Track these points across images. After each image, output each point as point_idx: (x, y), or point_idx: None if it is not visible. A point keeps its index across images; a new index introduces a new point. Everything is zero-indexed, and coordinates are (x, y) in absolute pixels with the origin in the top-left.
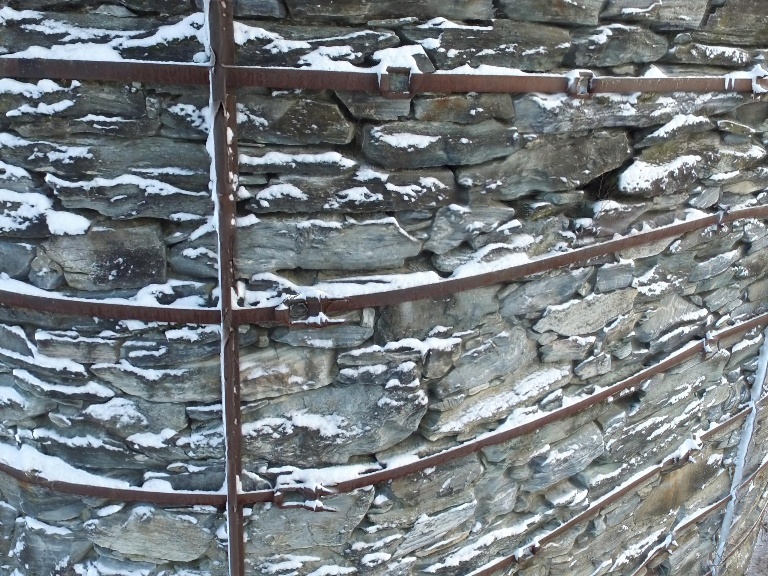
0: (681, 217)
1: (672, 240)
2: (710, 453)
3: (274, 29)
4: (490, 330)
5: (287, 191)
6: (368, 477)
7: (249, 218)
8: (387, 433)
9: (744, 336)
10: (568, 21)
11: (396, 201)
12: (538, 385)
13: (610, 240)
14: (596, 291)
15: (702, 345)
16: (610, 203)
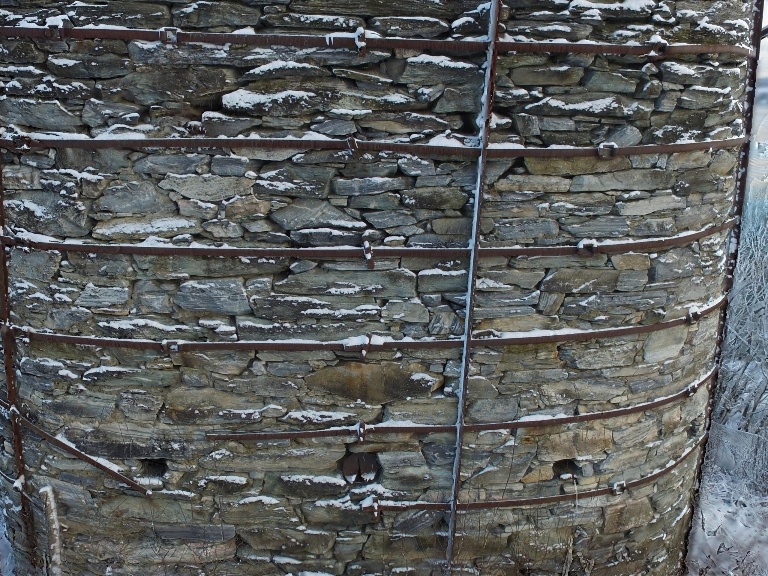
0: (299, 136)
1: (296, 153)
2: (419, 371)
3: (14, 11)
4: (126, 178)
5: (15, 84)
6: (53, 244)
7: (4, 96)
8: (68, 224)
9: (437, 265)
10: (160, 0)
11: (58, 92)
12: (169, 225)
13: (215, 138)
14: (212, 173)
15: (363, 252)
16: (215, 114)
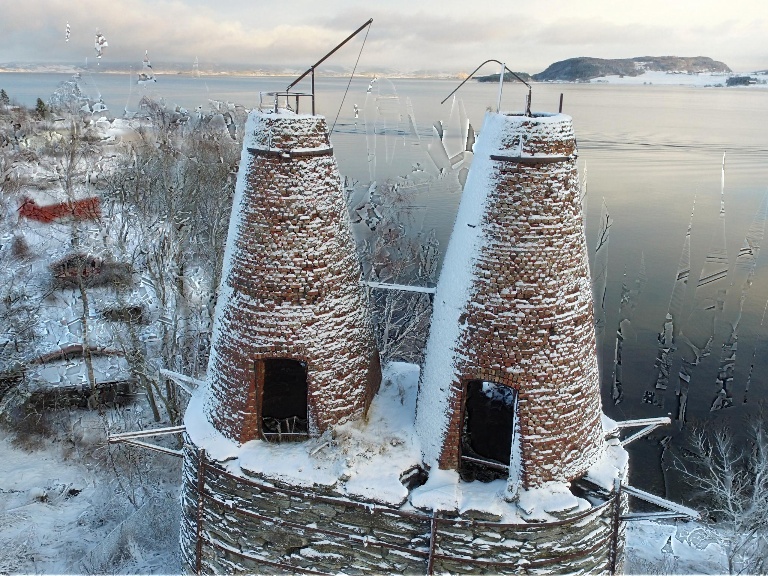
0: None
1: None
2: None
3: None
4: (255, 572)
5: None
6: None
7: None
8: None
9: None
10: None
11: None
12: None
13: (296, 567)
14: None
15: None
16: (297, 556)
